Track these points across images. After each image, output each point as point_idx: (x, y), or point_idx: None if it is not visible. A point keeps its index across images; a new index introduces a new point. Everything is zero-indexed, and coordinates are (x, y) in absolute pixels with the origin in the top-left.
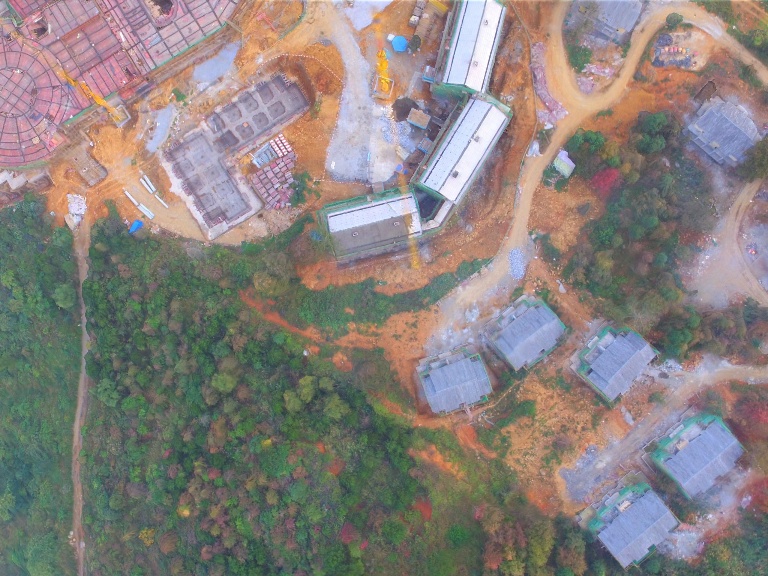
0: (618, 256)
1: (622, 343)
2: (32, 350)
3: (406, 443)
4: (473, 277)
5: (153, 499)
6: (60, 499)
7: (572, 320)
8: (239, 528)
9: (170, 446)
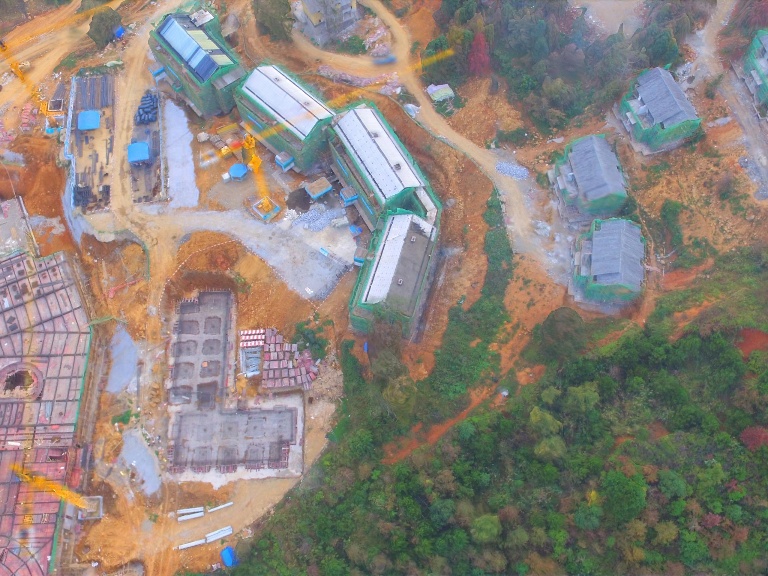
0: None
1: (646, 88)
2: None
3: (662, 338)
4: (504, 210)
5: None
6: None
7: None
8: None
9: None
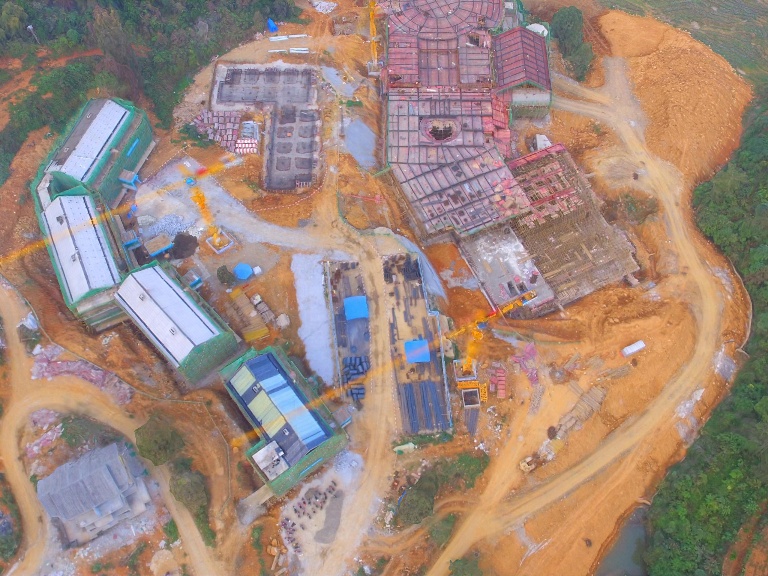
0: None
1: None
2: None
3: None
4: None
5: None
6: None
7: None
8: None
9: None
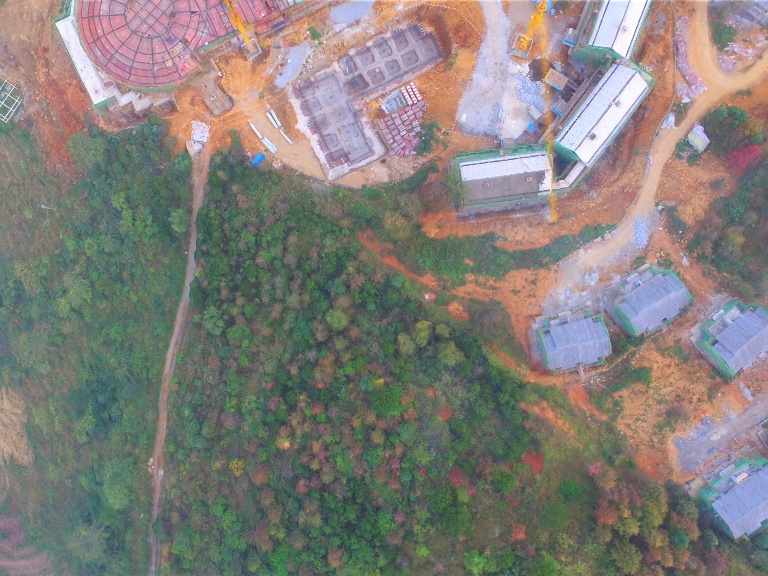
0: (747, 234)
1: (751, 317)
2: (133, 274)
3: (519, 396)
4: (596, 241)
5: (249, 430)
6: (144, 425)
7: (694, 293)
8: (339, 465)
9: (271, 379)
